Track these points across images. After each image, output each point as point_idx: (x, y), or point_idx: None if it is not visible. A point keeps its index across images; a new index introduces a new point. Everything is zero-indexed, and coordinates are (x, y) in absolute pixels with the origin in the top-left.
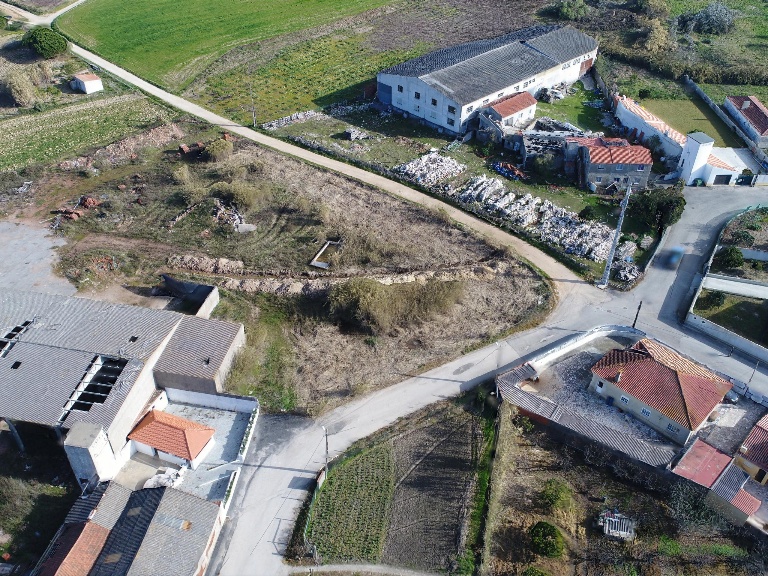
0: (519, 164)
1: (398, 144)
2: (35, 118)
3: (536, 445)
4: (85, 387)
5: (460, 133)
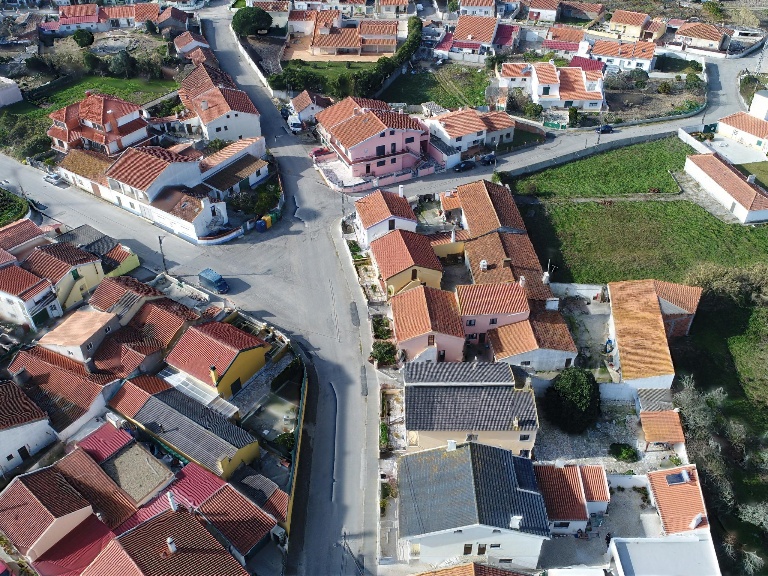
0: None
1: None
2: None
3: None
4: None
5: None
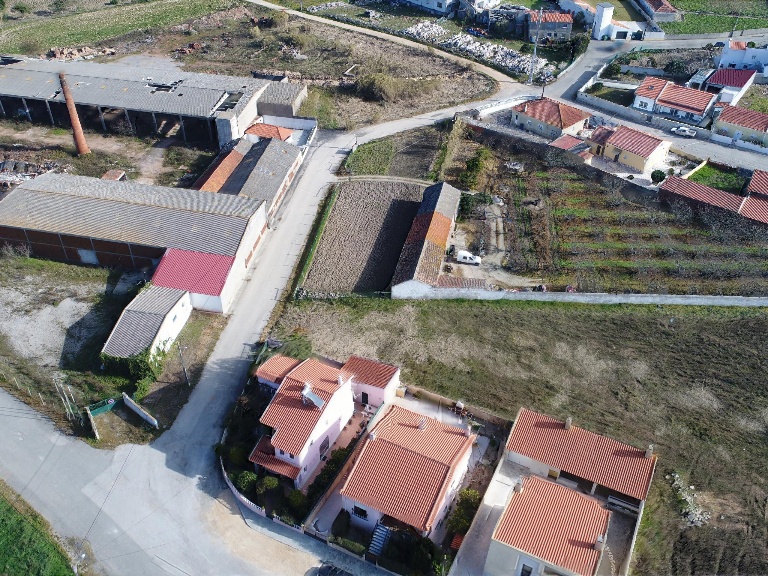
0: (485, 29)
1: (402, 20)
2: (145, 5)
3: (476, 142)
4: (221, 103)
5: (446, 13)
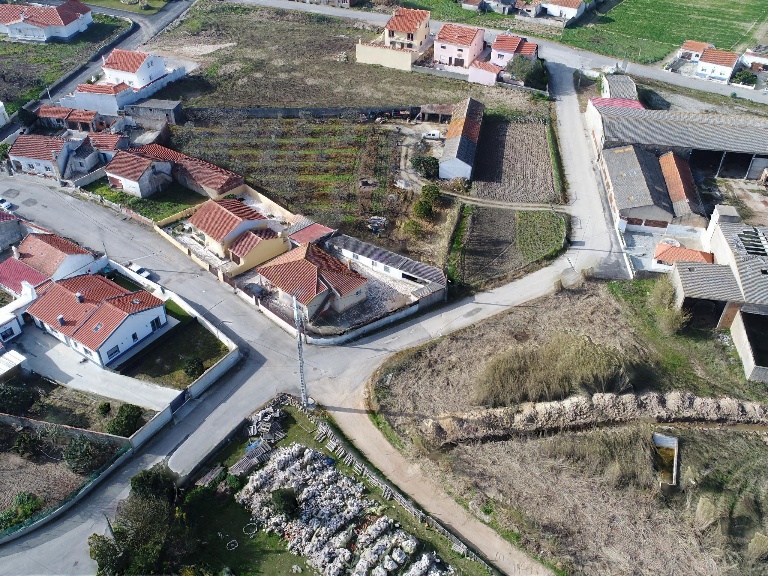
0: None
1: None
2: None
3: None
4: (763, 242)
5: None
